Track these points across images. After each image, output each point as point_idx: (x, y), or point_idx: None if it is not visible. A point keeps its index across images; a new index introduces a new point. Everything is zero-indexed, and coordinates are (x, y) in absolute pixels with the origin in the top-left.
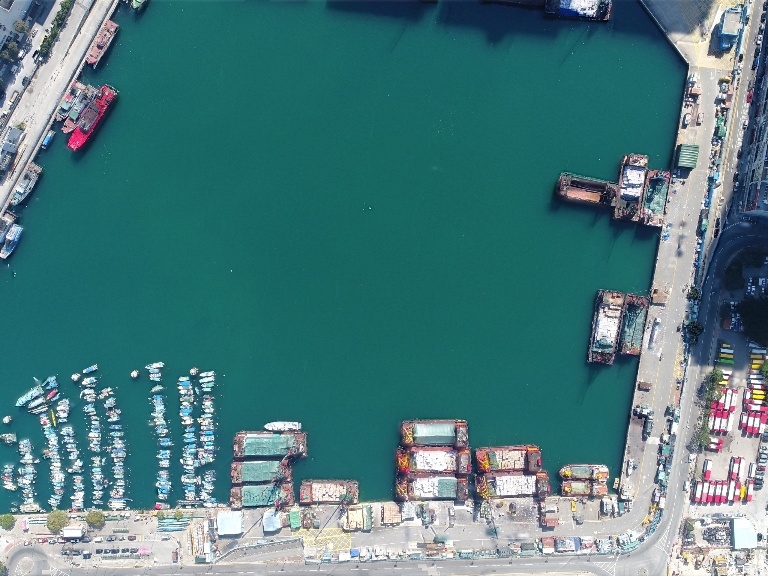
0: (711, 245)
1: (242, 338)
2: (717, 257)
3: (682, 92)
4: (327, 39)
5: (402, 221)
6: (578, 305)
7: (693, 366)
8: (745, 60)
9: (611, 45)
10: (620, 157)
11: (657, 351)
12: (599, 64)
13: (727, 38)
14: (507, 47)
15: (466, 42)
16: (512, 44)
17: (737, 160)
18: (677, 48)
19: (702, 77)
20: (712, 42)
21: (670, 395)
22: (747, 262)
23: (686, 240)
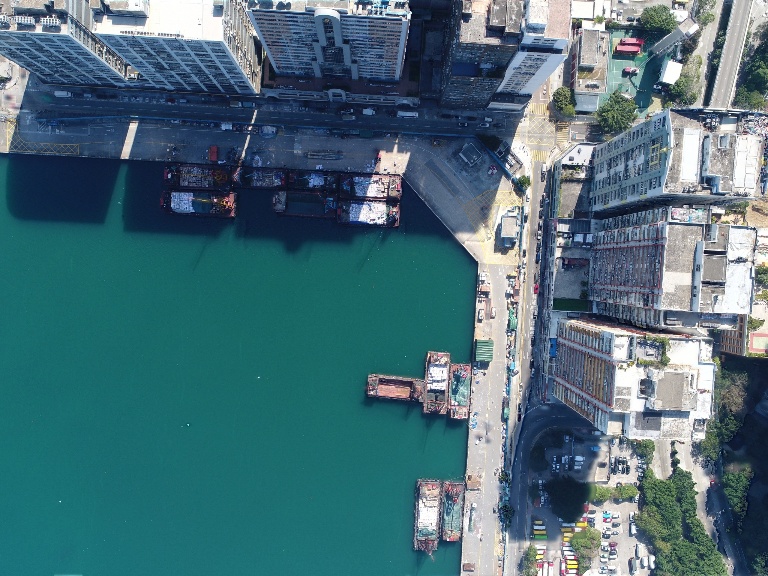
0: (516, 429)
1: (74, 563)
2: (523, 439)
3: (475, 287)
4: (128, 262)
5: (222, 432)
6: (400, 495)
7: (511, 543)
8: (529, 255)
9: (405, 248)
10: (424, 353)
11: (477, 533)
12: (395, 267)
13: (508, 238)
14: (306, 257)
15: (265, 256)
16: (311, 254)
17: (531, 348)
18: (465, 248)
19: (491, 273)
20: (497, 240)
21: (493, 572)
22: (548, 445)
23: (492, 427)
